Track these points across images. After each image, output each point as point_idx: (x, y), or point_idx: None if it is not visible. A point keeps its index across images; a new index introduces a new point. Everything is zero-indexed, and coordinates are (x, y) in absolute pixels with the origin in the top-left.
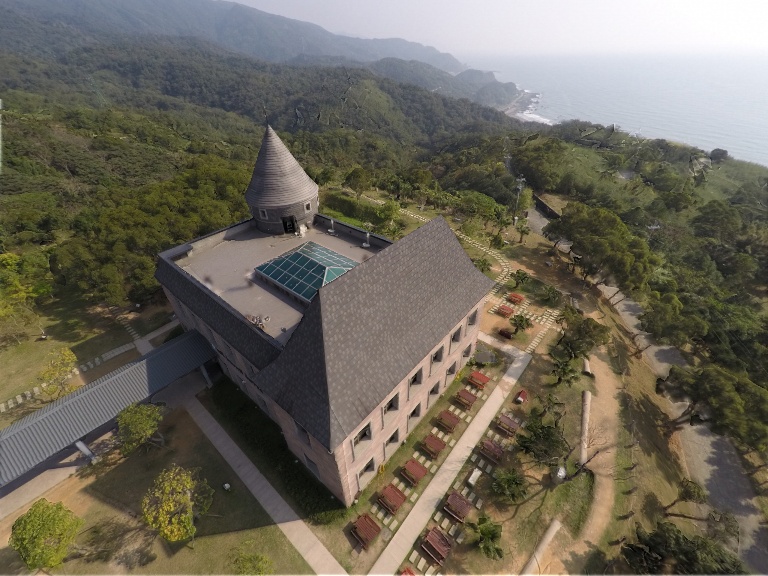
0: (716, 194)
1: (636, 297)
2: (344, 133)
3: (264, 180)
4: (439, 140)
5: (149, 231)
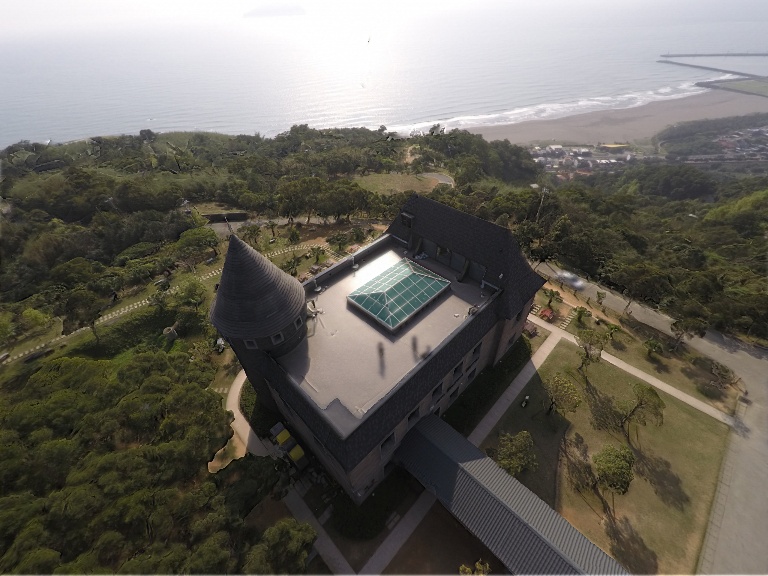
0: None
1: (354, 212)
2: None
3: (278, 291)
4: None
5: (170, 567)
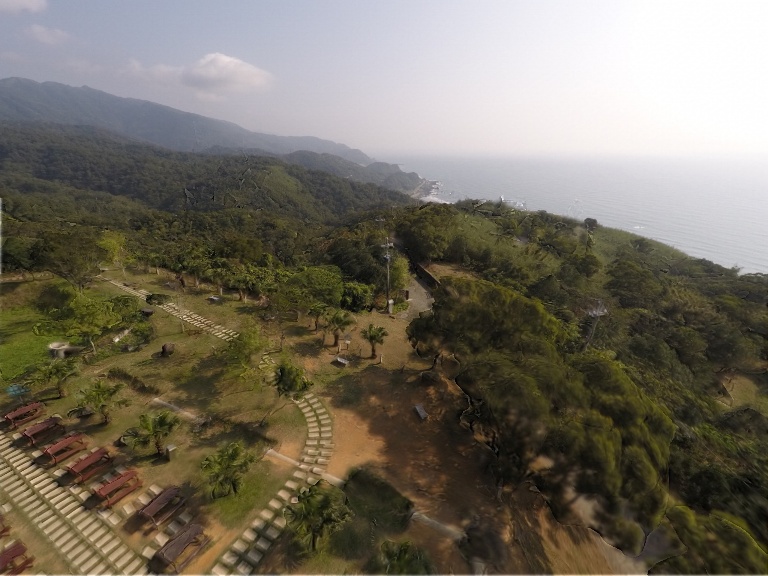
0: (605, 256)
1: None
2: (237, 212)
3: None
4: (343, 217)
5: None
